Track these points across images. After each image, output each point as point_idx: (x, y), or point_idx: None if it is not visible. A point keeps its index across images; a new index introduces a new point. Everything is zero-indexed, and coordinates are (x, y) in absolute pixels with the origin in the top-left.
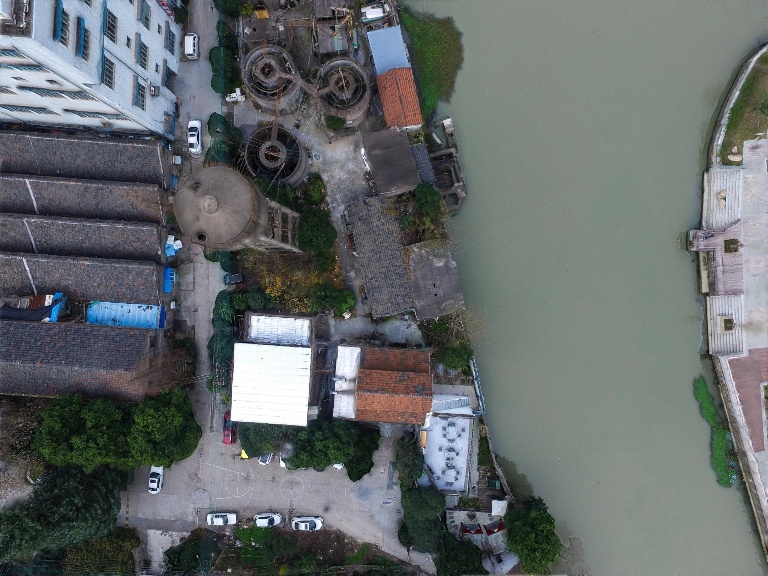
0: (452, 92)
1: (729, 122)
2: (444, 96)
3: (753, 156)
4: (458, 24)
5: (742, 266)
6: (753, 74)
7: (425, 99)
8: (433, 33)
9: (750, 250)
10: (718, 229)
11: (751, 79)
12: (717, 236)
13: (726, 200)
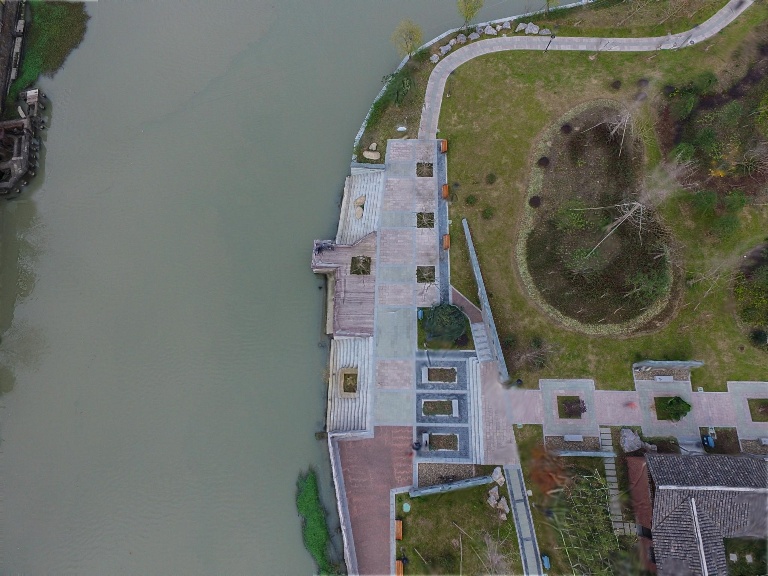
0: (59, 69)
1: (370, 117)
2: (48, 72)
3: (399, 157)
4: (88, 9)
5: (374, 295)
6: (403, 70)
7: (24, 72)
8: (57, 14)
9: (388, 274)
10: (349, 244)
11: (400, 74)
12: (341, 250)
13: (364, 208)
